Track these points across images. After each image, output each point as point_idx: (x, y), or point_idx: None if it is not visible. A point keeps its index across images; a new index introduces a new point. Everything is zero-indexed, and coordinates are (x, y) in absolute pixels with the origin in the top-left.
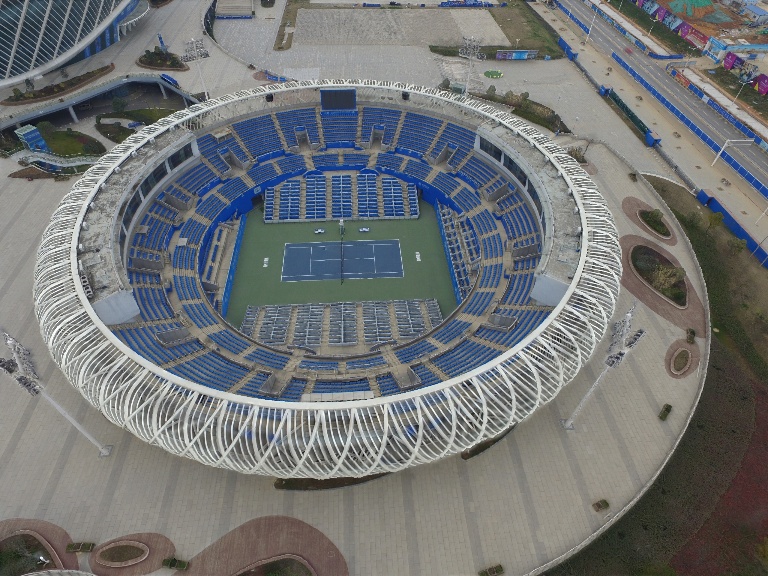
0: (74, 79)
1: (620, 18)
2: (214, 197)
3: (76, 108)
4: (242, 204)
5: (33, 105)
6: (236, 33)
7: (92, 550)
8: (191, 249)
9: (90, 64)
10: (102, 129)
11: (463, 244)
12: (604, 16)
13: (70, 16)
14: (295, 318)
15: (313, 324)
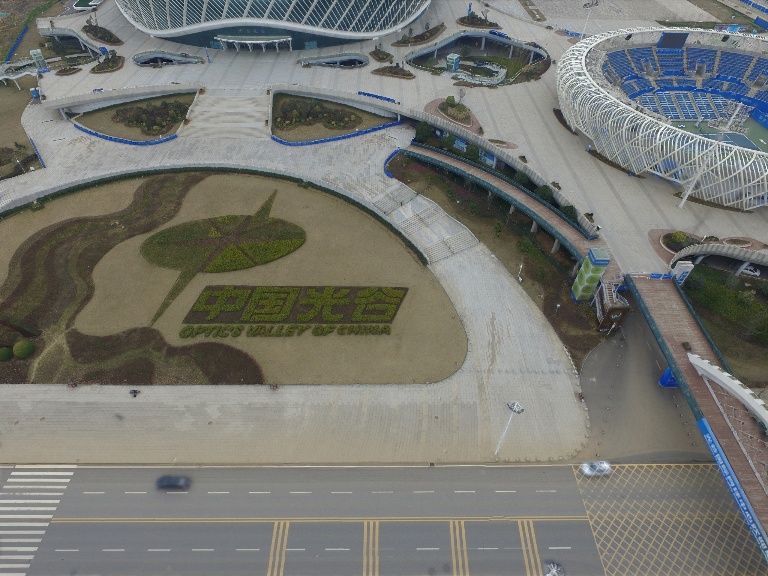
0: (433, 31)
1: None
2: None
3: None
4: None
5: (416, 47)
6: None
7: (718, 241)
8: None
9: (425, 23)
10: (460, 67)
11: None
12: None
13: None
14: None
15: None
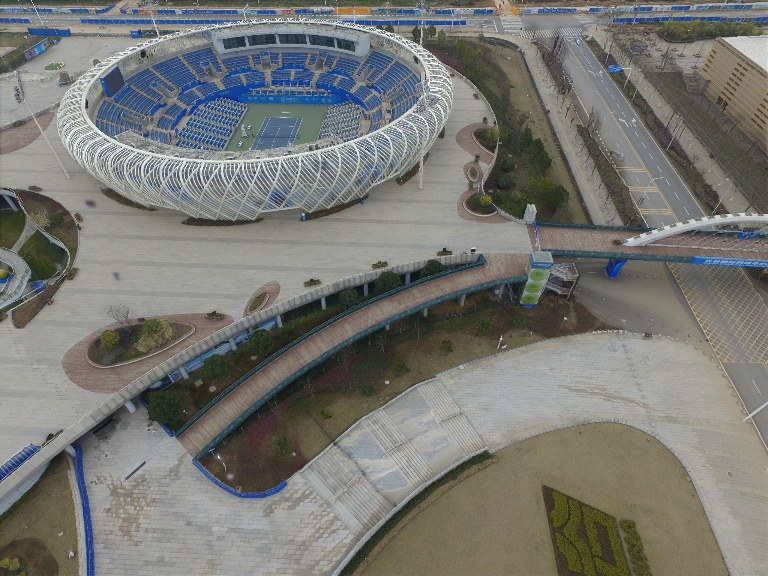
0: None
1: None
2: None
3: None
4: None
5: None
6: None
7: None
8: None
9: None
10: None
11: None
12: (5, 10)
13: None
14: None
15: None
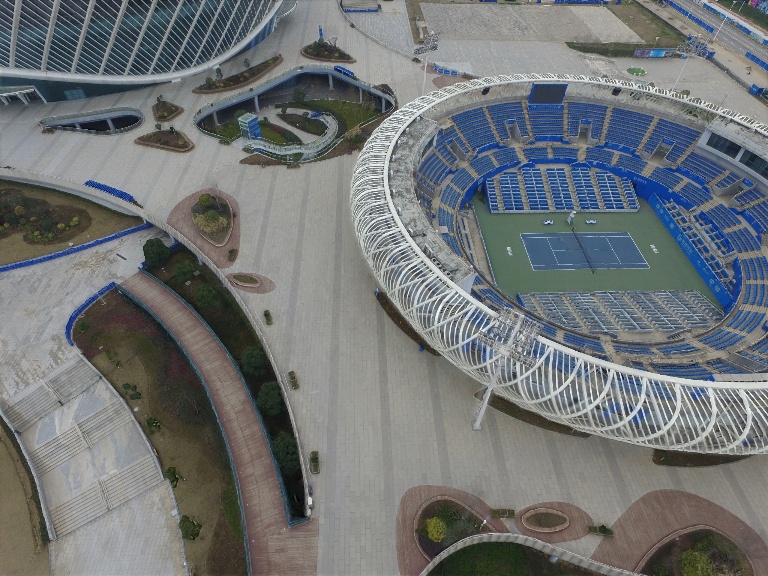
0: (255, 69)
1: (735, 17)
2: (450, 187)
3: (259, 97)
4: (468, 194)
5: (225, 94)
6: (370, 26)
7: (515, 516)
8: (452, 236)
9: (258, 54)
10: (287, 119)
11: (703, 238)
12: (720, 15)
13: (251, 7)
14: (569, 305)
15: (595, 311)
